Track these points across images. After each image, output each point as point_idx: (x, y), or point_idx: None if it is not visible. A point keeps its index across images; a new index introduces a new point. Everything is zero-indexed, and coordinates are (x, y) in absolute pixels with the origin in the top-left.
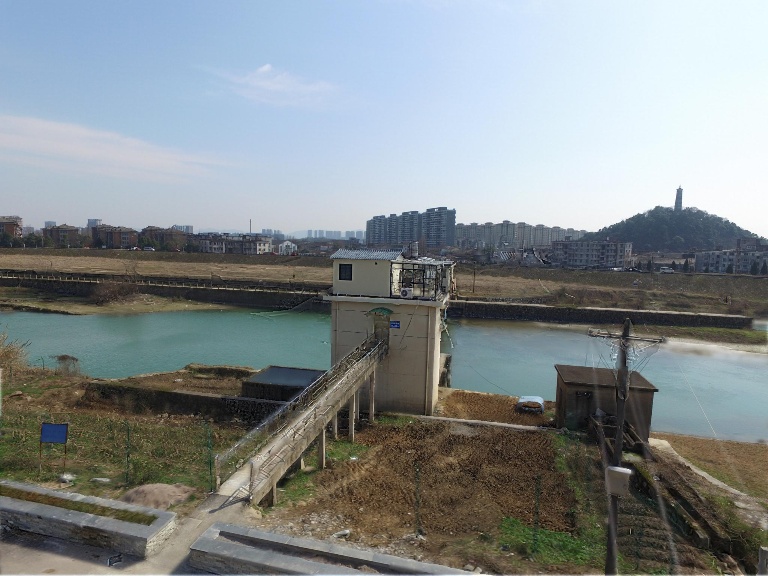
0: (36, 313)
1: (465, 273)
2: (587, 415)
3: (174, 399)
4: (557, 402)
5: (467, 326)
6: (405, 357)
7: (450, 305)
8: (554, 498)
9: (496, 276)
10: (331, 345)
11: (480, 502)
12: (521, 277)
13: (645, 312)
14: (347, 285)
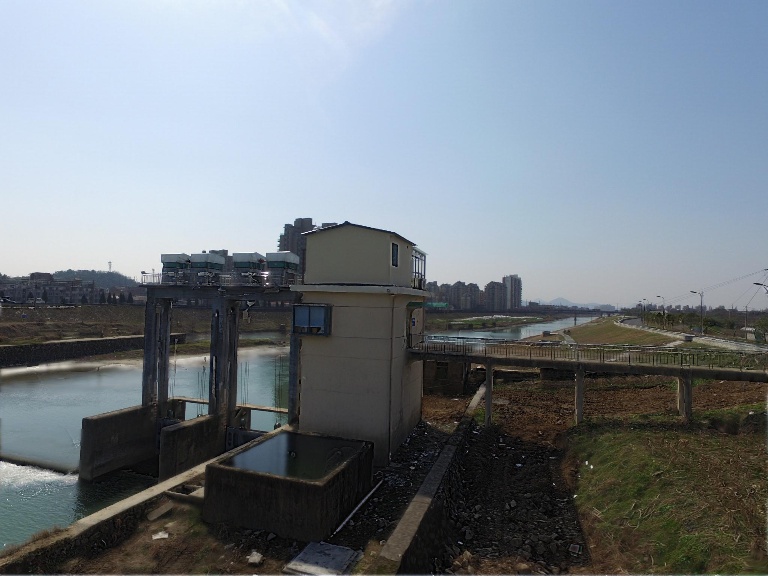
0: None
1: None
2: (465, 374)
3: (406, 575)
4: (432, 376)
5: None
6: None
7: None
8: (610, 391)
9: None
10: (388, 361)
11: None
12: None
13: (114, 339)
14: None
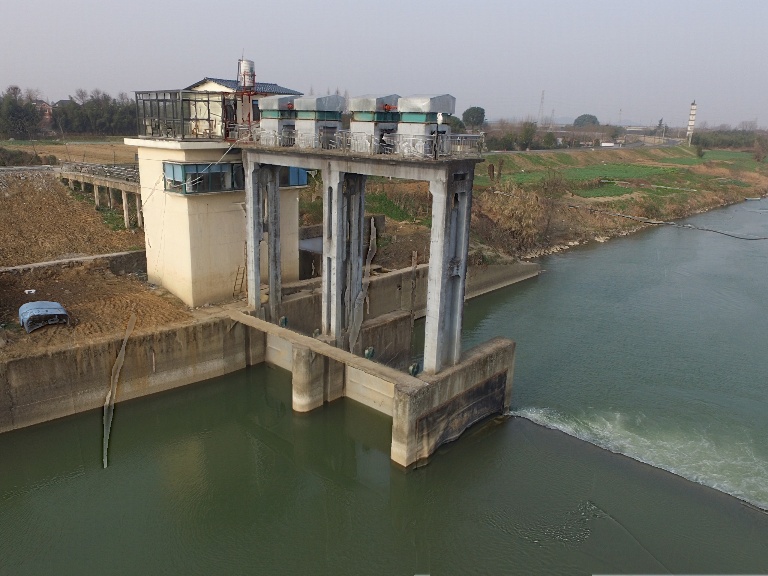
0: None
1: None
2: None
3: None
4: None
5: None
6: None
7: None
8: None
9: None
10: None
11: (2, 221)
12: None
13: None
14: None
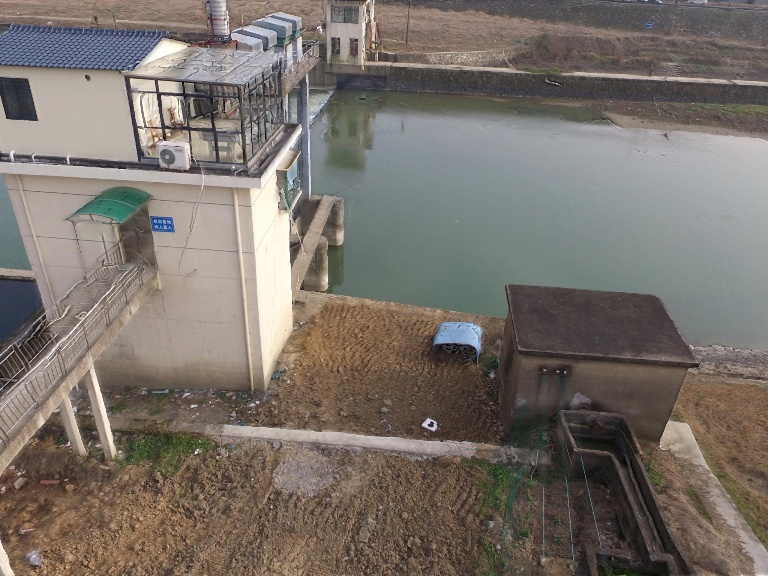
0: None
1: (394, 10)
2: (556, 403)
3: None
4: (504, 356)
5: (391, 110)
6: (196, 289)
7: (366, 71)
8: None
9: (446, 10)
10: None
11: None
12: (484, 12)
13: (660, 80)
14: (30, 132)
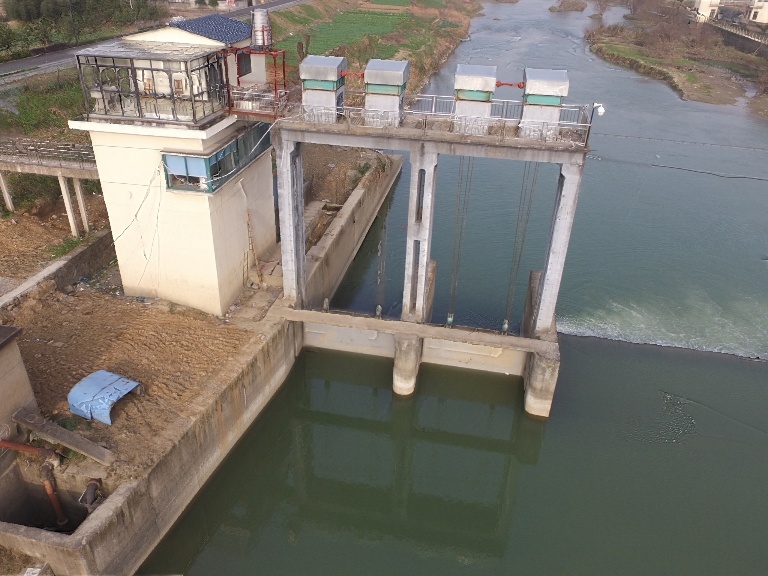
0: (669, 88)
1: None
2: None
3: None
4: None
5: None
6: None
7: None
8: None
9: None
10: None
11: None
12: None
13: None
14: None
